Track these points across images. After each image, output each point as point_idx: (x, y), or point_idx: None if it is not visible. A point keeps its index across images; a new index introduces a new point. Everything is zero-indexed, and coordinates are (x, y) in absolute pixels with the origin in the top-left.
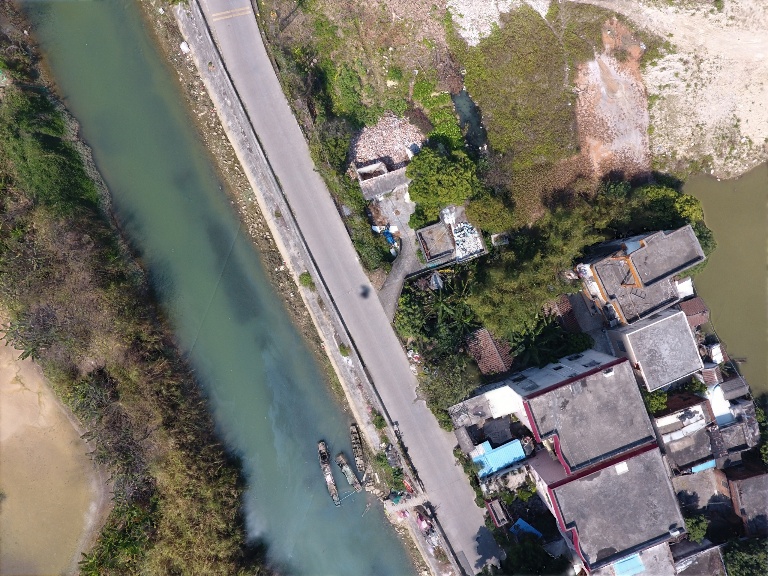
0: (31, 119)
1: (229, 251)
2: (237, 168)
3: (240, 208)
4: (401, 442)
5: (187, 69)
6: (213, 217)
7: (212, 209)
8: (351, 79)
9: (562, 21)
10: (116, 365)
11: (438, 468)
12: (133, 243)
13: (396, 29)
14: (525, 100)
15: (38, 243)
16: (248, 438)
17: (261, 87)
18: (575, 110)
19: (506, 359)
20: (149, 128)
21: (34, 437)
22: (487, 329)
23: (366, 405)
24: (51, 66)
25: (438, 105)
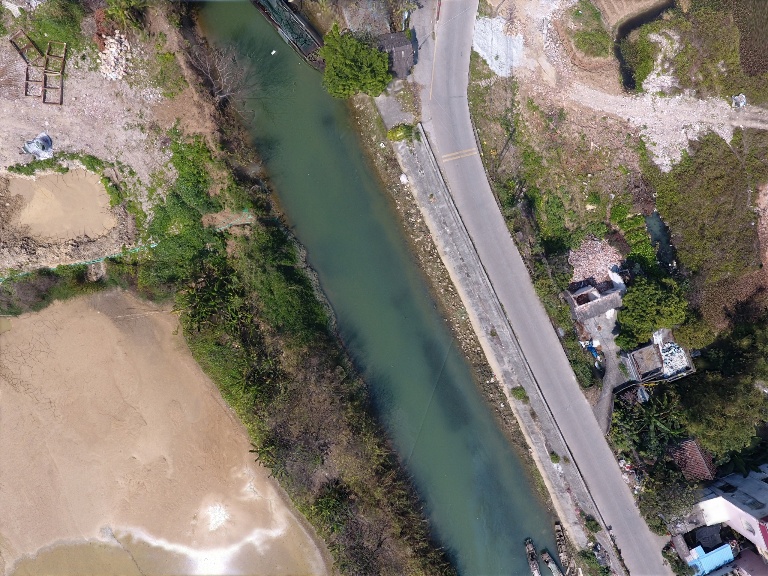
0: (274, 253)
1: (442, 365)
2: (451, 289)
3: (453, 325)
4: (616, 545)
5: (405, 198)
6: (428, 334)
7: (426, 326)
8: (557, 206)
9: (745, 147)
10: (356, 480)
11: (648, 568)
12: (356, 360)
13: (594, 157)
14: (712, 220)
15: (285, 369)
16: (462, 538)
17: (487, 222)
18: (757, 228)
19: (711, 468)
20: (366, 251)
21: (267, 541)
22: (695, 441)
23: (574, 507)
24: (280, 197)
25: (634, 227)
